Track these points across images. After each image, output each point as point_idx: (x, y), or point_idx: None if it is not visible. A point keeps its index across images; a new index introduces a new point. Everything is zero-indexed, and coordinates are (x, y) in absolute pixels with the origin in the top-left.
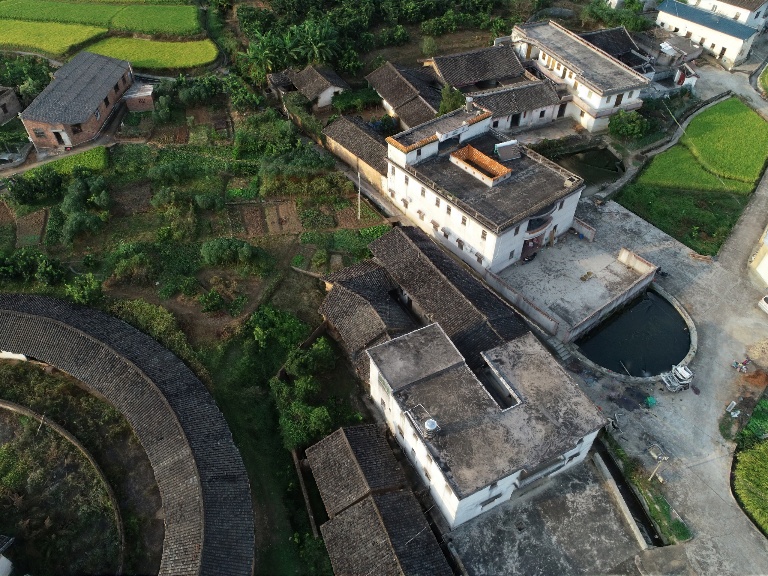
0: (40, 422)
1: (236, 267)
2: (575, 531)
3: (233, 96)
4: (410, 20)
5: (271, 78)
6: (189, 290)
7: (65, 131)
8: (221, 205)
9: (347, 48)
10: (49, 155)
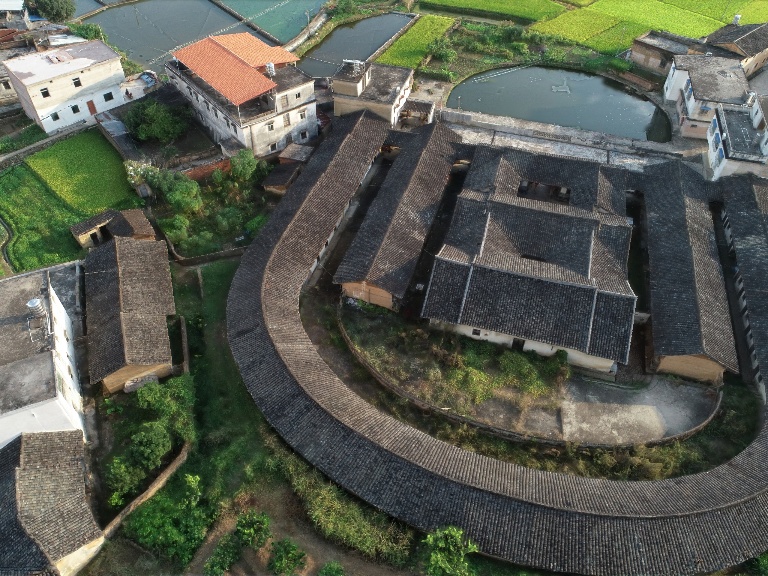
0: None
1: None
2: None
3: None
4: None
5: None
6: None
7: None
8: None
9: None
10: None
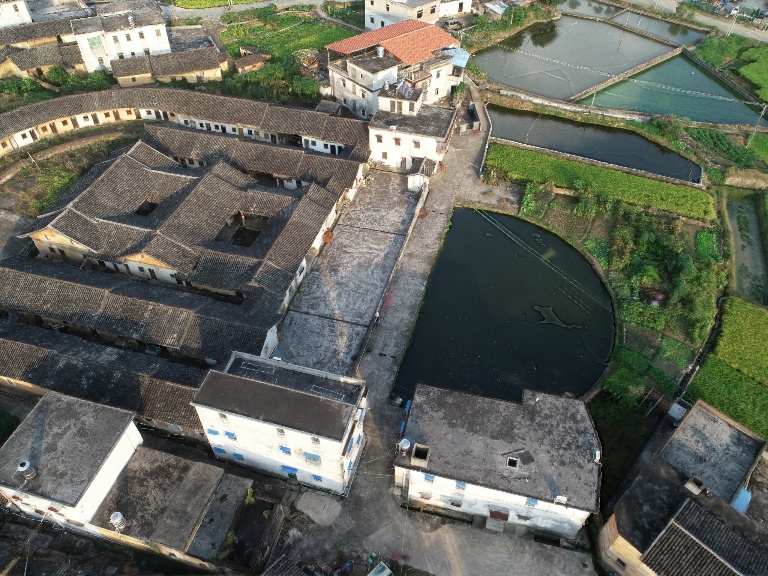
0: None
1: None
2: (188, 37)
3: None
4: None
5: None
6: None
7: None
8: None
9: None
10: None
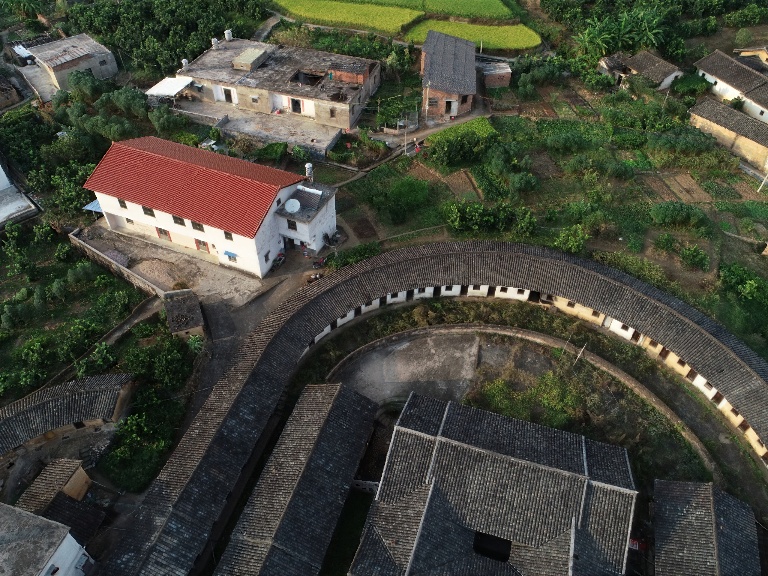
0: (573, 354)
1: (677, 229)
2: None
3: (583, 76)
4: (713, 12)
5: (606, 61)
6: None
7: (457, 101)
8: (632, 173)
9: (672, 36)
10: (437, 123)
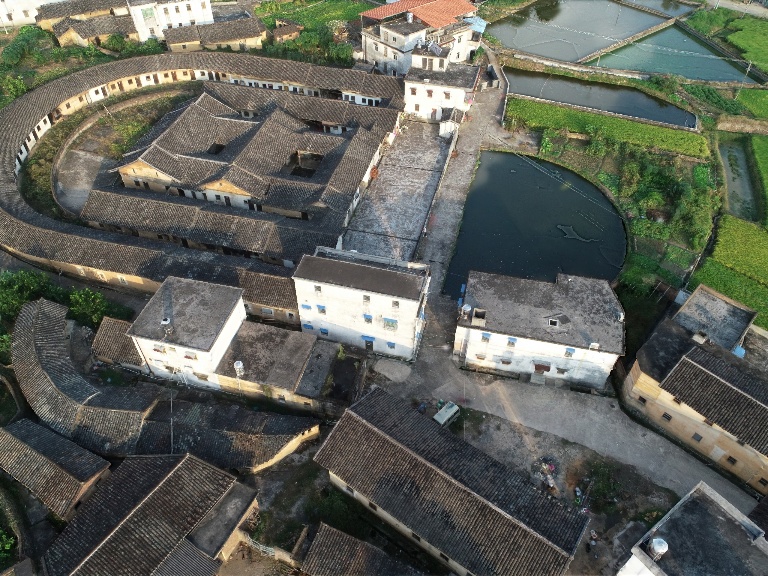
0: None
1: (24, 62)
2: (225, 12)
3: None
4: None
5: None
6: (44, 58)
7: None
8: None
9: None
10: None
